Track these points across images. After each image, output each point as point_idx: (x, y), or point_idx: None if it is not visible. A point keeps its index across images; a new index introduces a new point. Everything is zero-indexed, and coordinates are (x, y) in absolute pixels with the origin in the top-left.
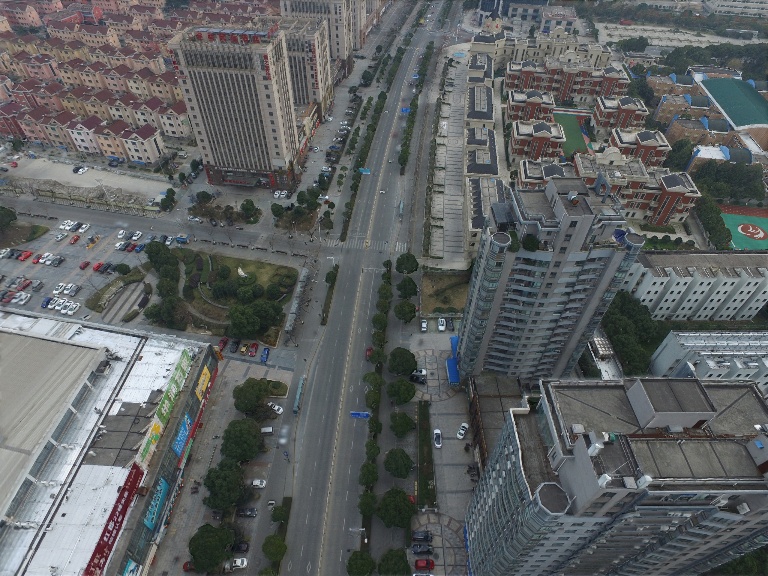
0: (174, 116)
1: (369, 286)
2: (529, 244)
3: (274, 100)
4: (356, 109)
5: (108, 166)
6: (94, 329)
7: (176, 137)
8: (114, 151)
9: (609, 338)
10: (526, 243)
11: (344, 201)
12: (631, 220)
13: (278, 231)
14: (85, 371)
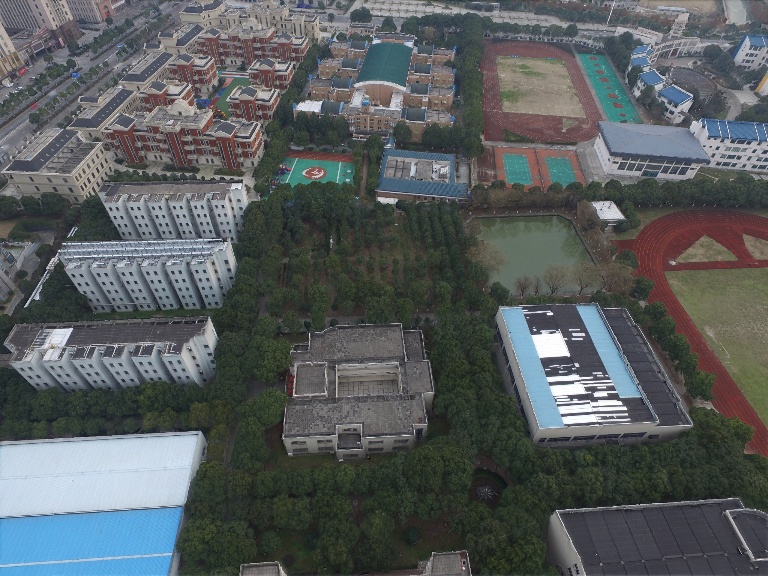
0: None
1: None
2: None
3: None
4: None
5: None
6: None
7: None
8: None
9: None
10: None
11: None
12: (212, 166)
13: None
14: None
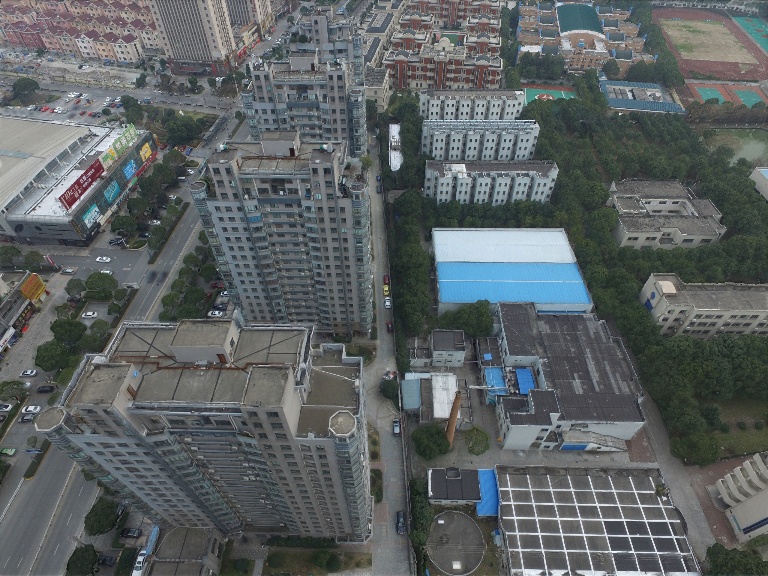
0: (150, 31)
1: None
2: (300, 38)
3: (208, 4)
4: None
5: (103, 65)
6: (84, 125)
7: (153, 49)
8: (107, 55)
9: (400, 138)
10: (299, 38)
11: None
12: None
13: (213, 98)
14: (76, 134)
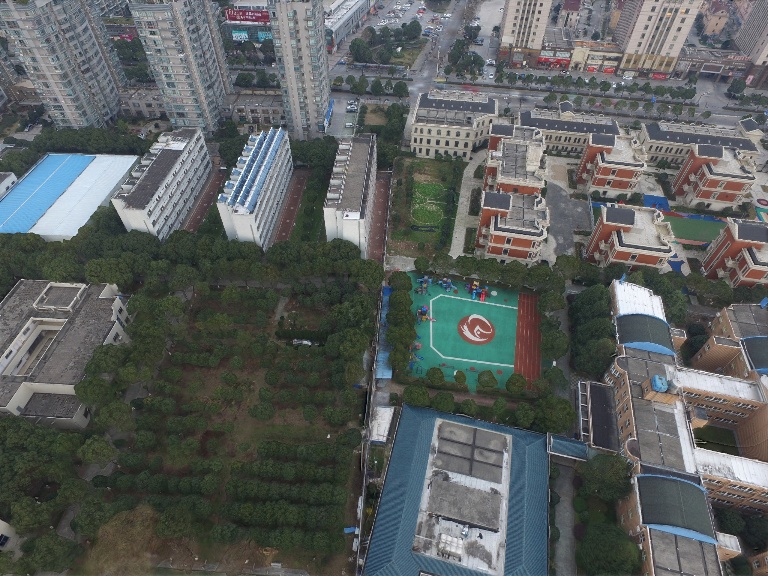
0: None
1: None
2: None
3: None
4: None
5: None
6: None
7: None
8: None
9: None
10: None
11: (488, 83)
12: None
13: (447, 63)
14: None
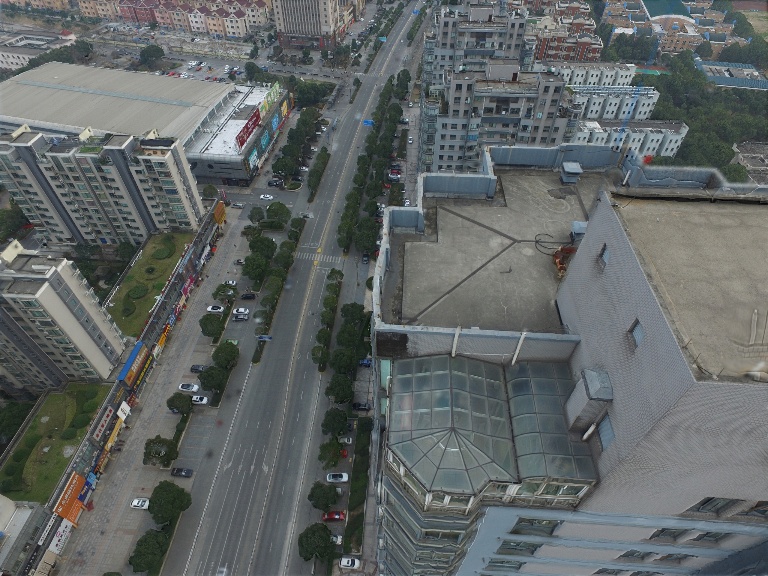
0: (256, 9)
1: (380, 91)
2: (452, 1)
3: None
4: (381, 15)
5: None
6: None
7: (256, 26)
8: (217, 29)
9: None
10: (450, 1)
11: None
12: None
13: (324, 68)
14: (227, 89)
